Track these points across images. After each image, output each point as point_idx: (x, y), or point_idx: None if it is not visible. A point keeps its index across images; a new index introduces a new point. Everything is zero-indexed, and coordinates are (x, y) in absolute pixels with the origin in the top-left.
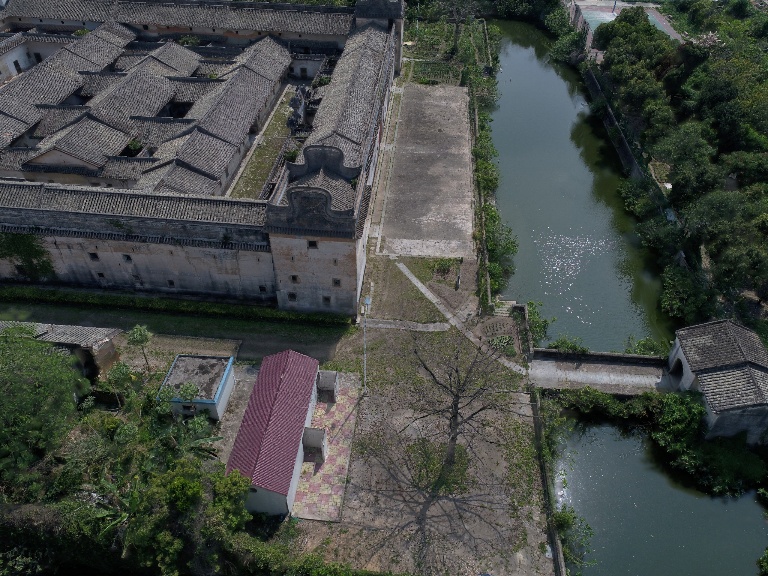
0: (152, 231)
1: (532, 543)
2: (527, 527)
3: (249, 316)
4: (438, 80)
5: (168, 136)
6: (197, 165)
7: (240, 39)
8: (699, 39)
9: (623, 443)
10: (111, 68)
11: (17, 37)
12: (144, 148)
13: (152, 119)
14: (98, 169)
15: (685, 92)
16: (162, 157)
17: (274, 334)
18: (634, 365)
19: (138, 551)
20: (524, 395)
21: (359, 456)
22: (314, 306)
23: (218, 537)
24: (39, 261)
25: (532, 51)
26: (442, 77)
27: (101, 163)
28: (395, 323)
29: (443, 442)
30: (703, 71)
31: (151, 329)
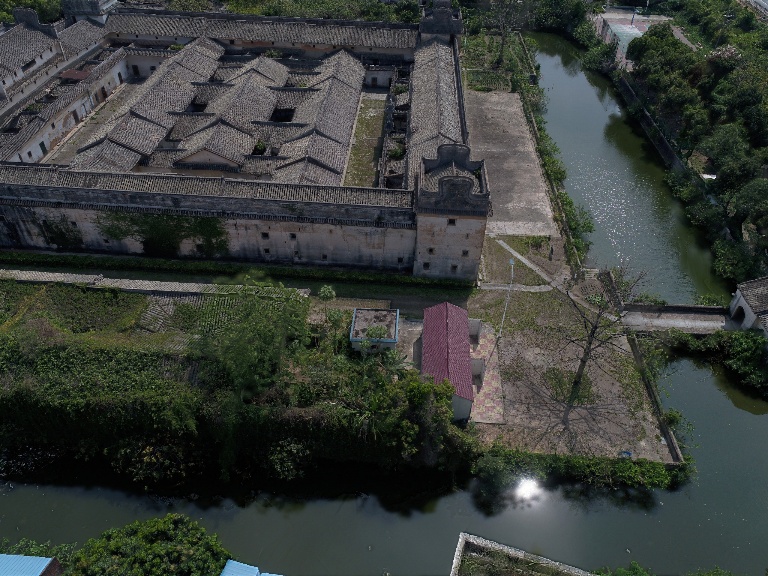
0: (319, 214)
1: (650, 435)
2: (644, 425)
3: (392, 282)
4: (491, 87)
5: (286, 138)
6: (323, 162)
7: (316, 52)
8: (717, 51)
9: (698, 372)
10: (211, 79)
11: (120, 51)
12: (268, 148)
13: (271, 124)
14: (238, 166)
15: (712, 97)
16: (291, 156)
17: (415, 295)
18: (702, 314)
19: (384, 436)
20: (622, 336)
21: (507, 380)
22: (443, 273)
23: (444, 423)
24: (217, 240)
25: (558, 59)
26: (494, 85)
27: (241, 161)
28: (508, 286)
29: (568, 370)
30: (724, 79)
31: (315, 293)
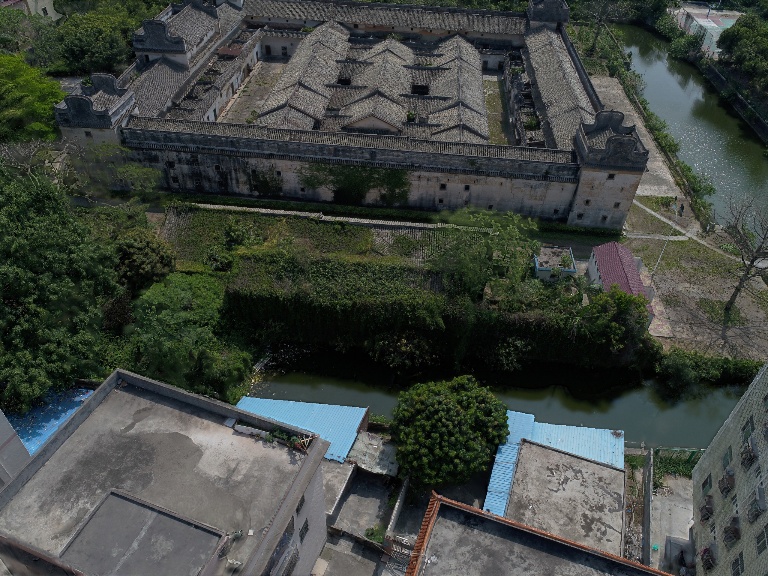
0: (495, 168)
1: None
2: None
3: (551, 229)
4: (591, 72)
5: (431, 109)
6: (474, 129)
7: (432, 37)
8: None
9: None
10: None
11: (258, 32)
12: (417, 118)
13: (417, 96)
14: (398, 131)
15: None
16: (443, 123)
17: (571, 241)
18: None
19: (594, 335)
20: (757, 276)
21: (668, 306)
22: (593, 223)
23: (644, 326)
24: (400, 190)
25: (635, 50)
26: (592, 70)
27: (401, 127)
28: (650, 235)
29: (718, 300)
30: None
31: None
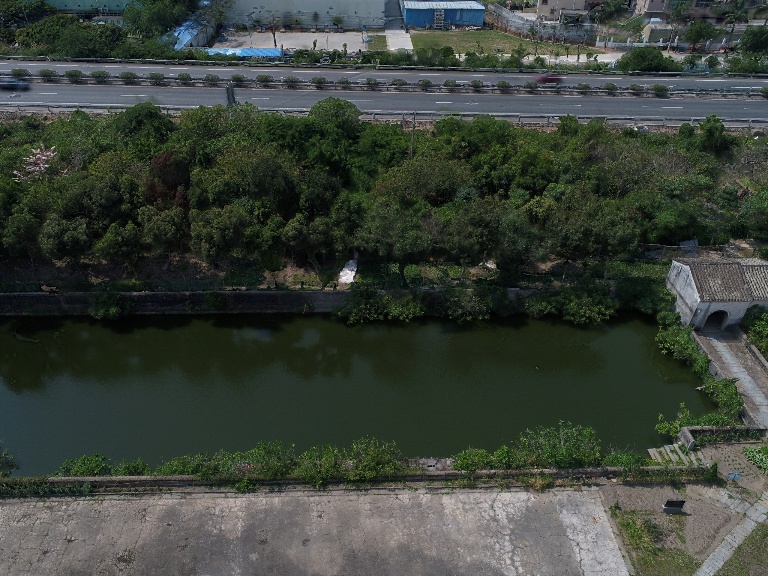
0: None
1: None
2: None
3: None
4: None
5: None
6: None
7: None
8: (8, 168)
9: None
10: None
11: None
12: None
13: None
14: None
15: None
16: None
17: None
18: None
19: None
20: None
21: None
22: None
23: None
24: None
25: None
26: None
27: None
28: None
29: None
30: None
31: None
